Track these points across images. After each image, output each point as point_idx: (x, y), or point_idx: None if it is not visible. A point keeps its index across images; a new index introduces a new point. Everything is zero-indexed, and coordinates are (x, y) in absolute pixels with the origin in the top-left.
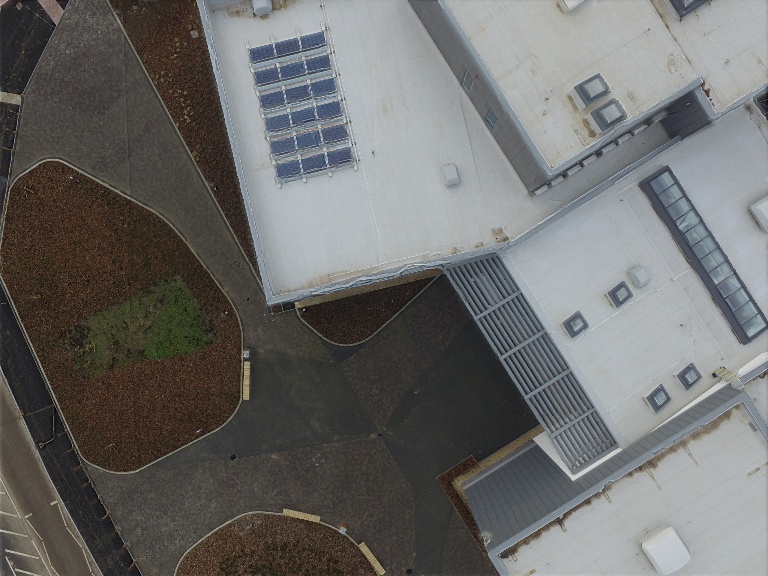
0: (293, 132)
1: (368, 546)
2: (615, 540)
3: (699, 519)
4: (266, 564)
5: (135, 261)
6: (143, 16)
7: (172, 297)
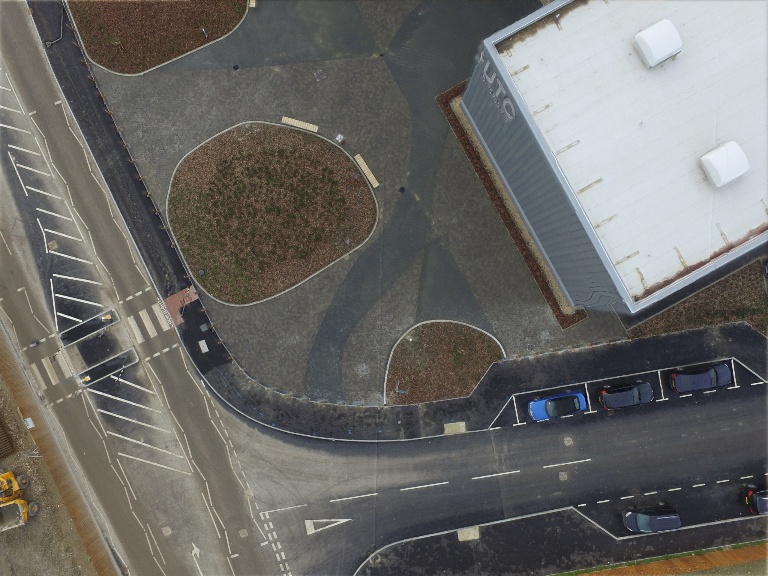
0: None
1: None
2: (609, 40)
3: (693, 22)
4: (262, 168)
5: None
6: None
7: None
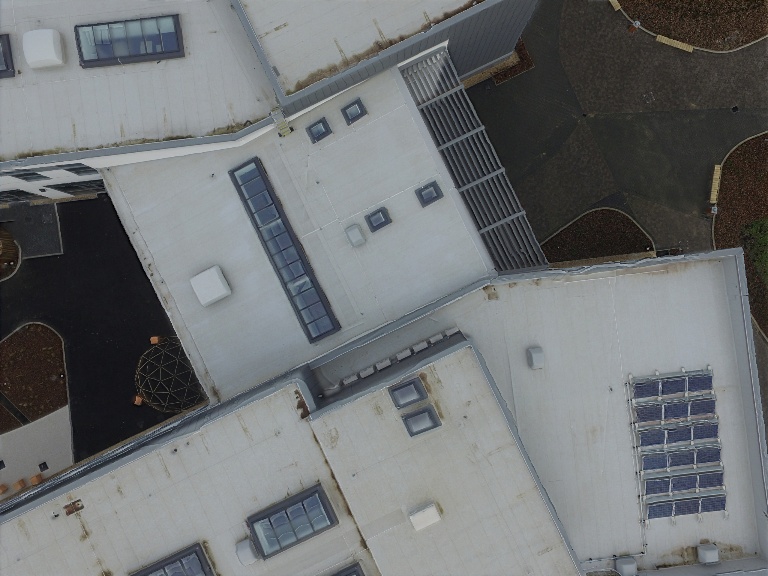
0: (690, 420)
1: (610, 7)
2: None
3: None
4: None
5: None
6: None
7: None
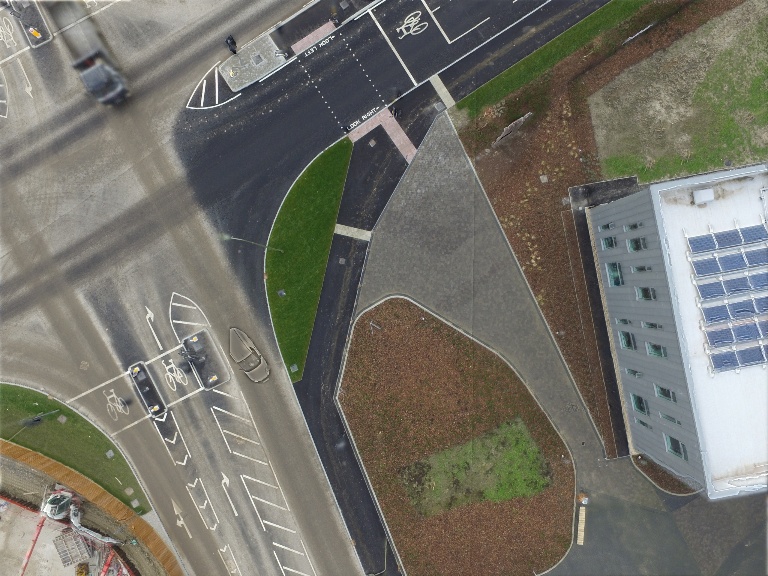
0: (729, 323)
1: None
2: None
3: None
4: None
5: (480, 403)
6: (495, 159)
7: (513, 440)
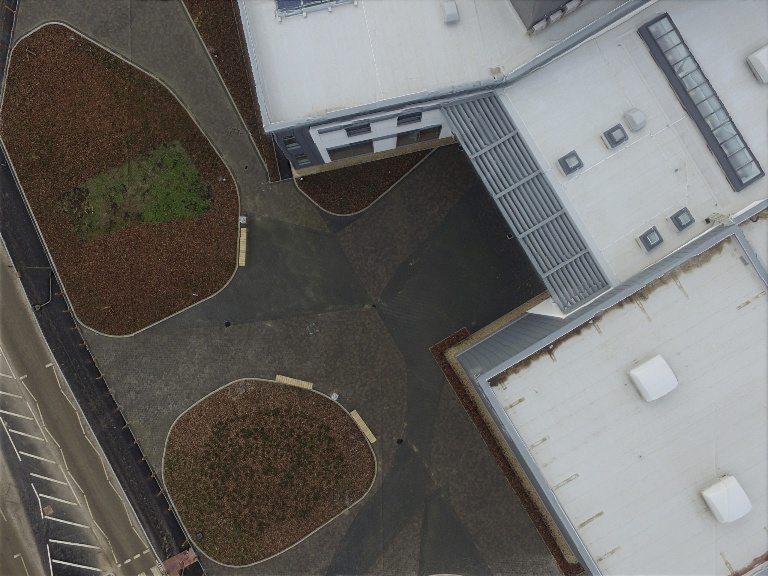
0: None
1: (360, 415)
2: (604, 370)
3: (688, 351)
4: (258, 428)
5: (135, 124)
6: None
7: (171, 161)
